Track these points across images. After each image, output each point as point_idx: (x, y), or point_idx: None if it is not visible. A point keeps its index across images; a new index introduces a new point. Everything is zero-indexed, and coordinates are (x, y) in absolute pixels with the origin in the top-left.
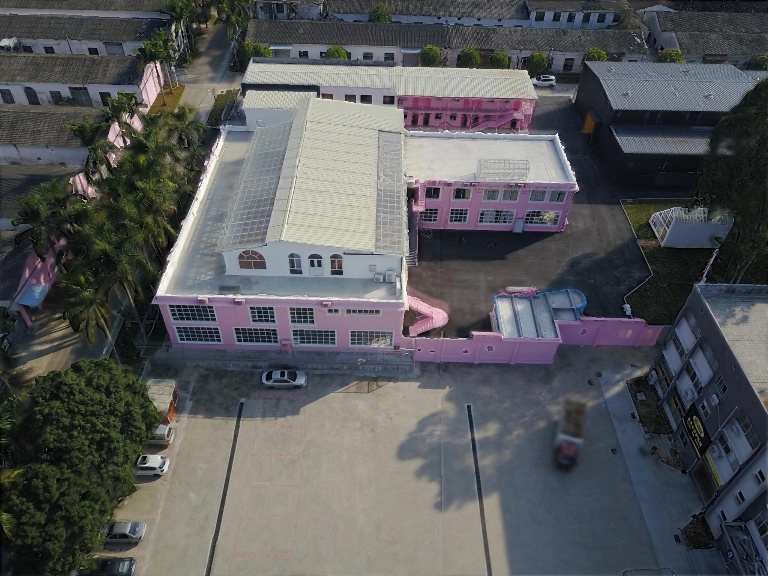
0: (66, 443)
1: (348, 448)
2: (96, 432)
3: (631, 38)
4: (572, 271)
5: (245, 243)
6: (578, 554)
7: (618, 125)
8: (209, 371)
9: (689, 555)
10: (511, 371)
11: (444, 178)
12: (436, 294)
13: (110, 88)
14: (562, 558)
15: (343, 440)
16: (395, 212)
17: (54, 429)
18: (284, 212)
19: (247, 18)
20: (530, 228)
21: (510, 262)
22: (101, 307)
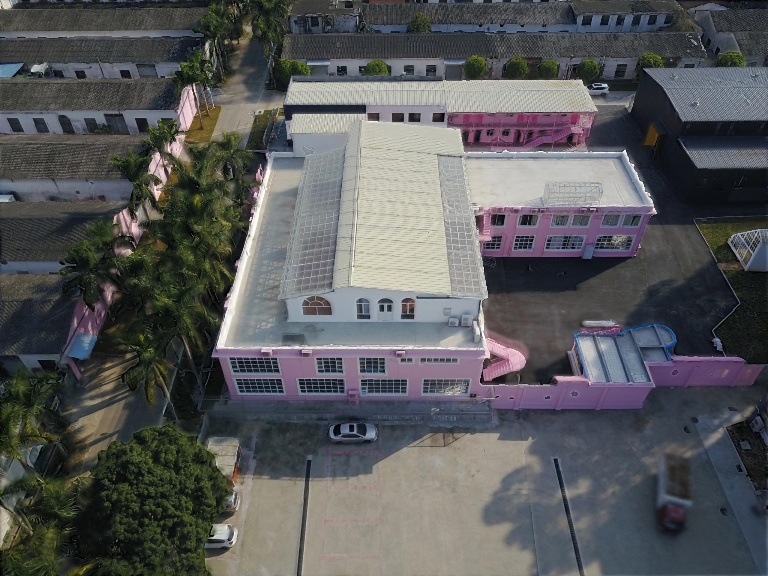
0: (138, 533)
1: (429, 512)
2: (168, 517)
3: (687, 40)
4: (651, 301)
5: (310, 289)
6: None
7: (687, 137)
8: (271, 424)
9: None
10: (597, 418)
11: (509, 204)
12: (507, 331)
13: (146, 114)
14: None
15: (423, 503)
16: (467, 248)
17: (124, 517)
18: (349, 253)
19: (282, 33)
20: (600, 253)
21: (583, 293)
22: (159, 364)
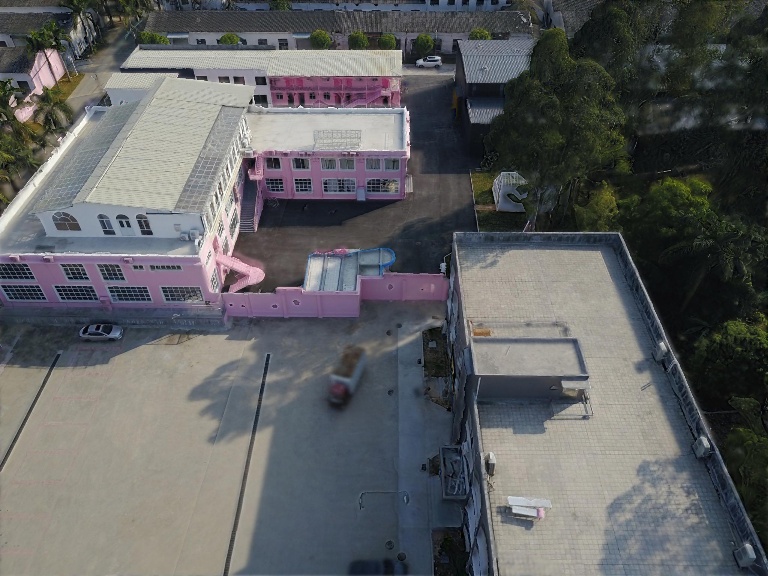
0: None
1: (143, 392)
2: None
3: (518, 18)
4: (402, 234)
5: (56, 205)
6: (327, 481)
7: (475, 98)
8: (36, 327)
9: (429, 481)
10: (318, 324)
11: (284, 149)
12: (266, 256)
13: (3, 77)
14: (312, 484)
15: (141, 385)
16: (208, 177)
17: None
18: (98, 177)
19: (150, 10)
20: (374, 196)
21: (345, 227)
22: None
